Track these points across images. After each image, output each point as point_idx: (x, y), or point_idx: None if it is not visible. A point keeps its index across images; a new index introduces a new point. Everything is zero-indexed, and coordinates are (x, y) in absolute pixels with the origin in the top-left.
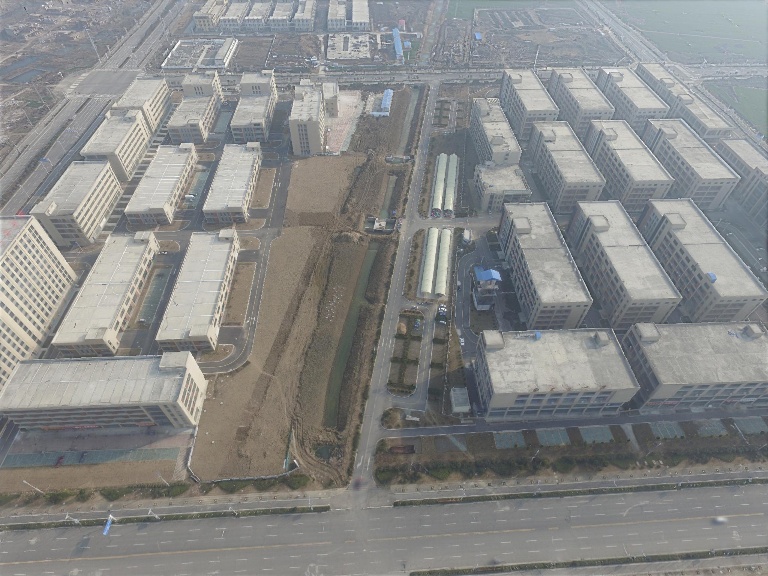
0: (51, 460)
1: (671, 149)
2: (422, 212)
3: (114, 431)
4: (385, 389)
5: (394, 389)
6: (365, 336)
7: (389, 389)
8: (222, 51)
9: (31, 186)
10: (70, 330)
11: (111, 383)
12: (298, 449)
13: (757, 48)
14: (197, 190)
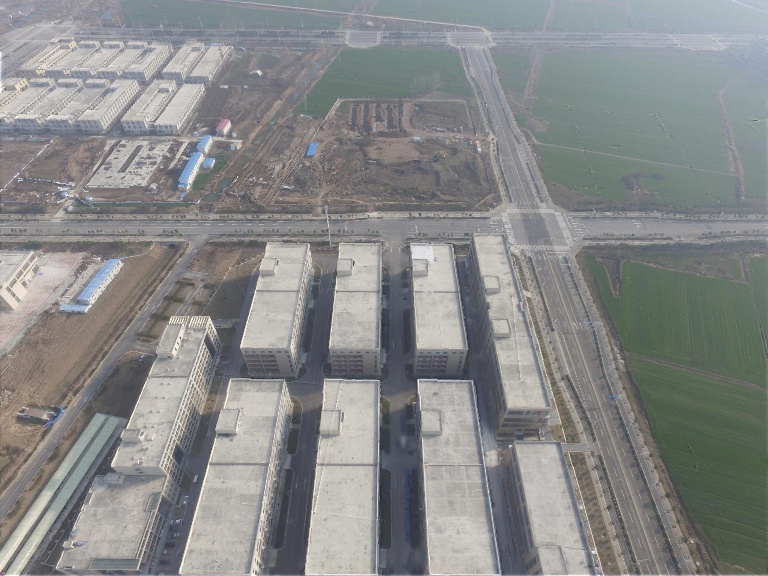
0: None
1: (422, 464)
2: None
3: None
4: None
5: None
6: None
7: None
8: None
9: None
10: None
11: None
12: None
13: (682, 180)
14: None
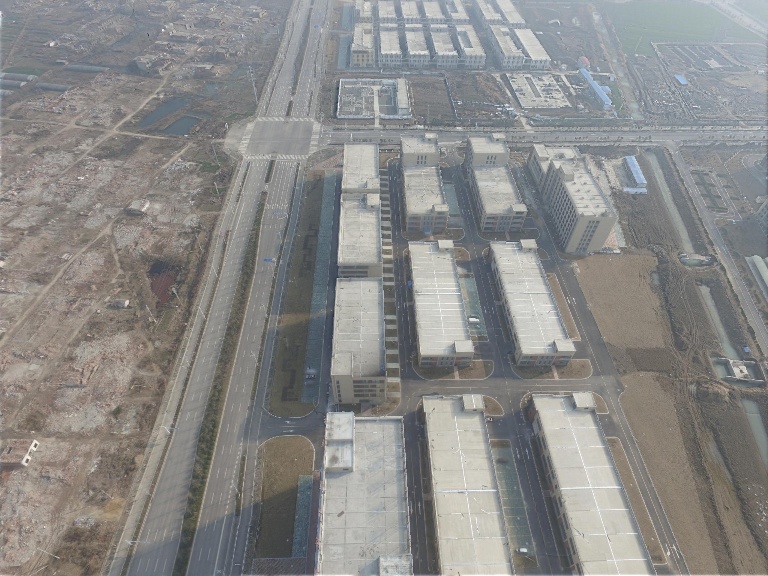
0: None
1: None
2: None
3: None
4: None
5: None
6: None
7: None
8: (402, 97)
9: (261, 298)
10: None
11: None
12: None
13: None
14: (475, 308)
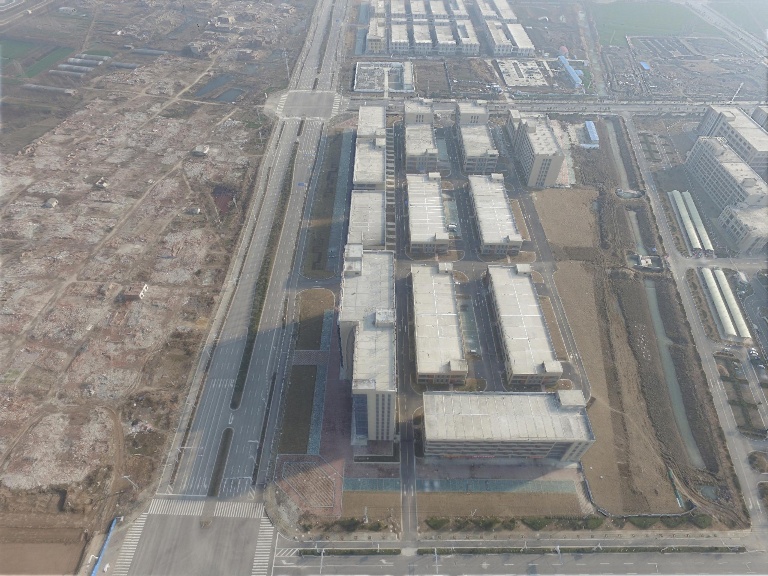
0: (460, 487)
1: None
2: (682, 251)
3: (504, 461)
4: (738, 432)
5: (748, 432)
6: (691, 377)
7: (742, 432)
8: (407, 75)
9: None
10: (427, 360)
11: (520, 418)
12: (685, 488)
13: None
14: (454, 220)
